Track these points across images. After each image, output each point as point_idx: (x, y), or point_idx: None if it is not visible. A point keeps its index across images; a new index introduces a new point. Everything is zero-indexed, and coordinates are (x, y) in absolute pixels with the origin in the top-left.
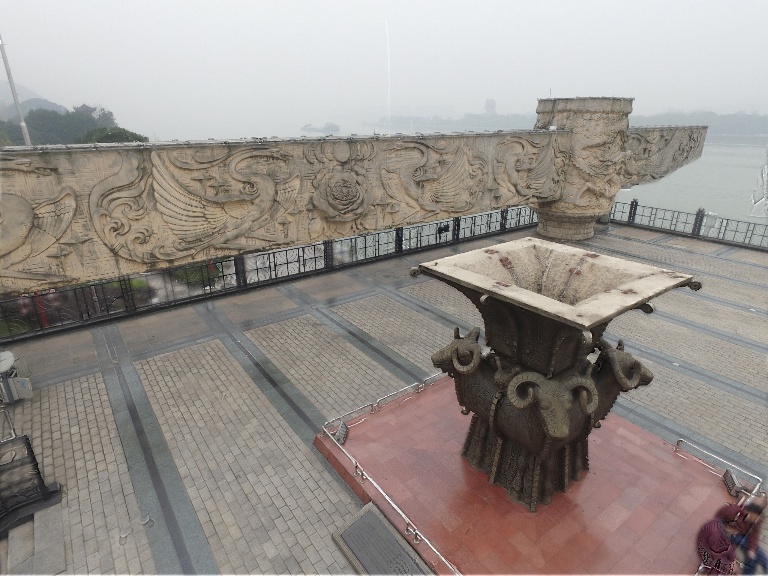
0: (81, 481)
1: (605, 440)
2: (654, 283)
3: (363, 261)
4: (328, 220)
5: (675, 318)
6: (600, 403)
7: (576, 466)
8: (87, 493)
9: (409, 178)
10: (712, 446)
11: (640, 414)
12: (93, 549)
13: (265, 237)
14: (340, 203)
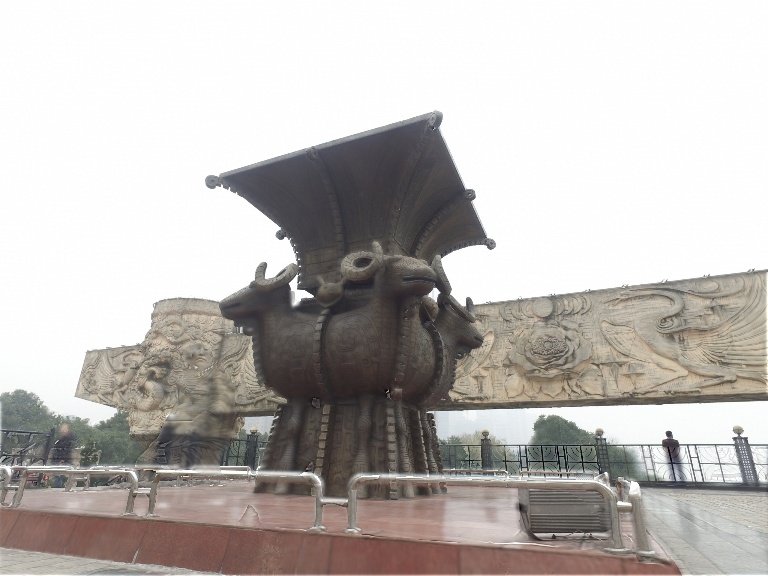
0: None
1: None
2: None
3: (670, 484)
4: (528, 377)
5: None
6: (353, 323)
7: (353, 465)
8: None
9: (651, 330)
10: None
11: None
12: None
13: (458, 389)
14: (541, 358)
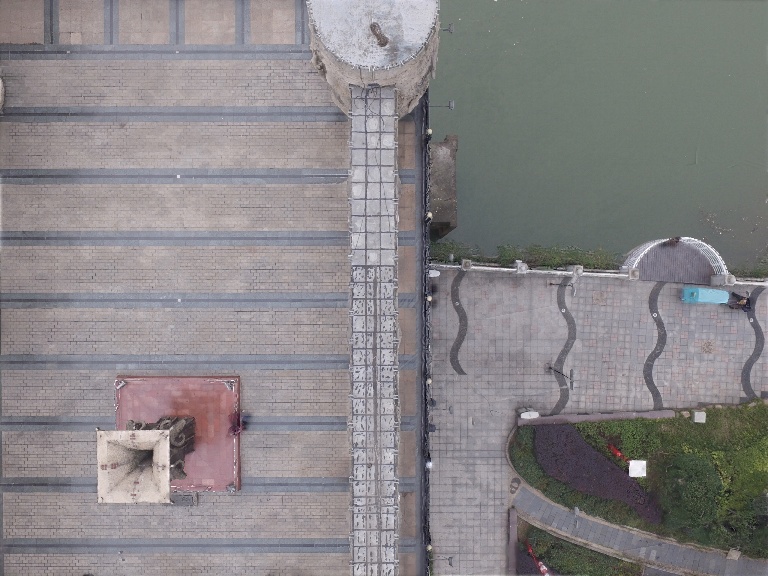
0: (86, 569)
1: (189, 398)
2: (164, 451)
3: None
4: None
5: (152, 236)
6: None
7: None
8: (94, 567)
9: None
10: (217, 359)
11: (189, 362)
12: (121, 568)
13: None
14: None
